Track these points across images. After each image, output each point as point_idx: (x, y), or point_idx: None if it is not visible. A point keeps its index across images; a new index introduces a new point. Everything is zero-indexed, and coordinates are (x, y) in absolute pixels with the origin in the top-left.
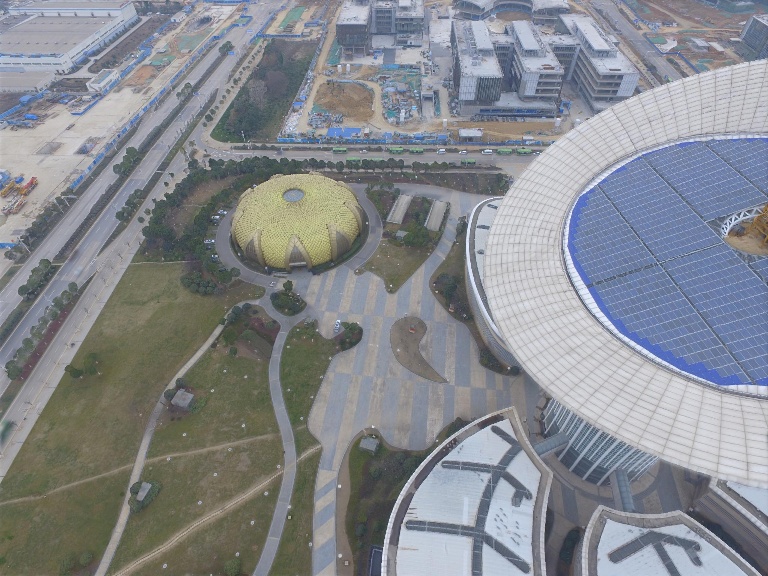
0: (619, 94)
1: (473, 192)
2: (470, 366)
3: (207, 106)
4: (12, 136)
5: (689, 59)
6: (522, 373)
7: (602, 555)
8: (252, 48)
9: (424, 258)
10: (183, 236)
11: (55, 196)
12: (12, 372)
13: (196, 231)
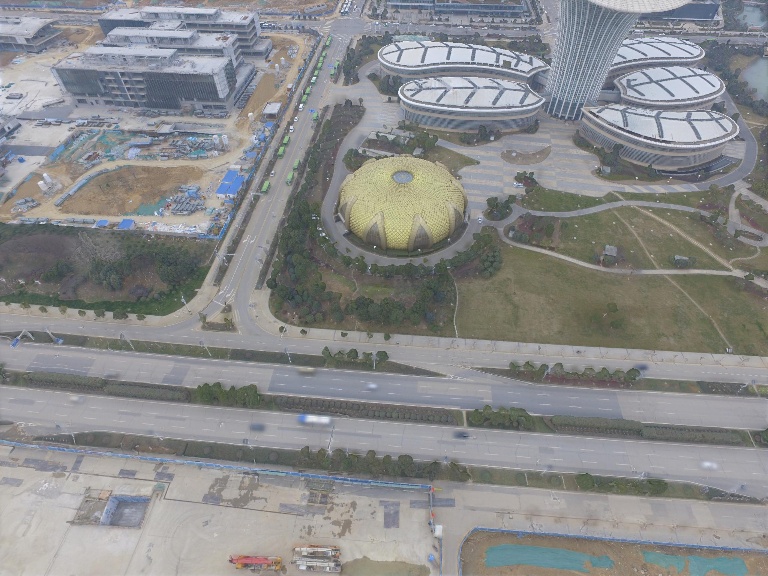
0: (258, 34)
1: (359, 120)
2: (536, 138)
3: None
4: None
5: None
6: None
7: None
8: None
9: (440, 147)
10: None
11: (292, 500)
12: None
13: (424, 267)
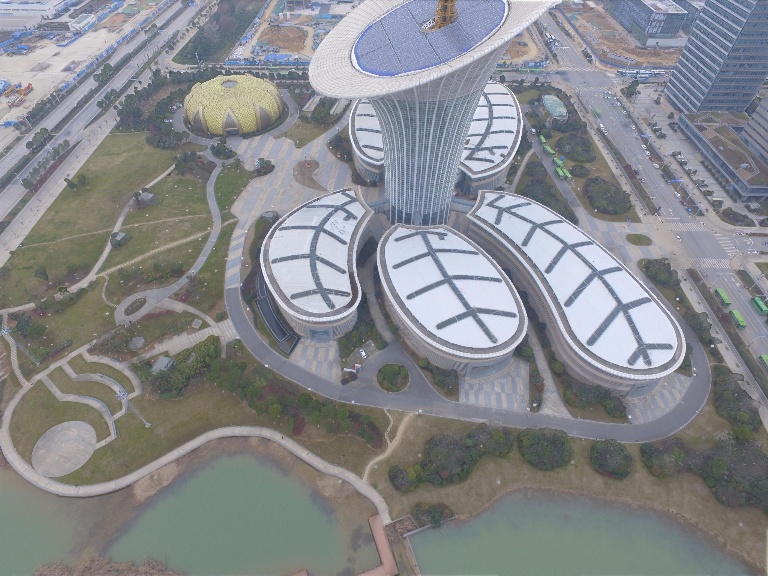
0: None
1: None
2: (345, 183)
3: (170, 41)
4: (8, 60)
5: (566, 12)
6: (379, 186)
7: (391, 239)
8: (210, 2)
9: (326, 130)
10: (148, 116)
11: (48, 96)
12: (27, 183)
13: (158, 111)
